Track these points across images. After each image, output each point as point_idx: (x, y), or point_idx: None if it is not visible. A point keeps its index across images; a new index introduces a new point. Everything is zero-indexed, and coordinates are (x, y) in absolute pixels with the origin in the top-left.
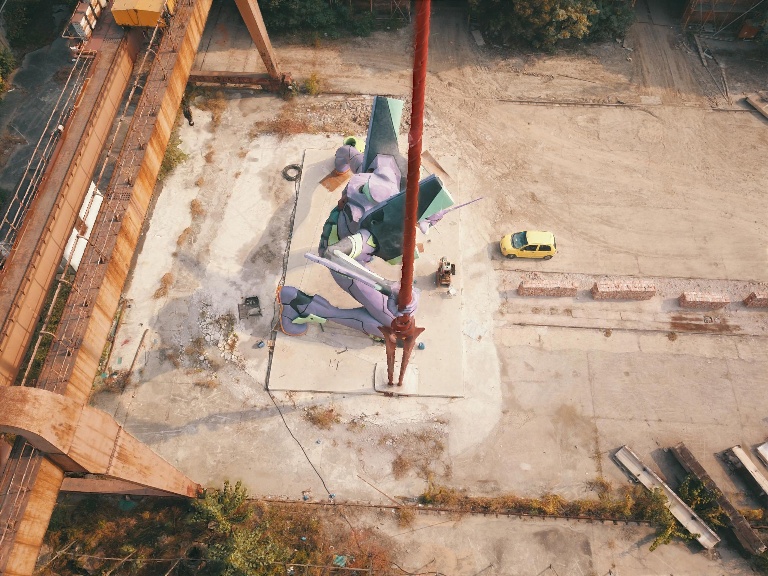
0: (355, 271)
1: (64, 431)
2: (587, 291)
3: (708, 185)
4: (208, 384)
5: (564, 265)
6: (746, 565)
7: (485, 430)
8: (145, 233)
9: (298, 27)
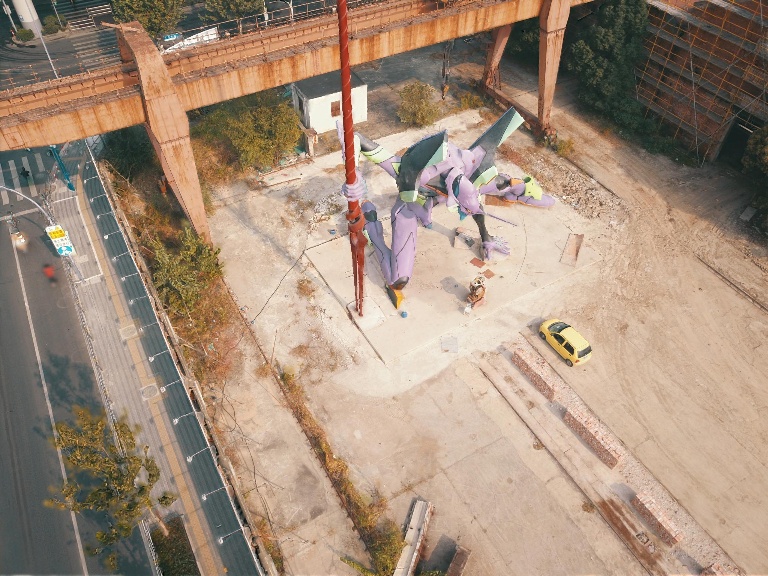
0: None
1: (154, 88)
2: None
3: None
4: (285, 222)
5: (576, 381)
6: None
7: (369, 392)
8: None
9: (607, 116)
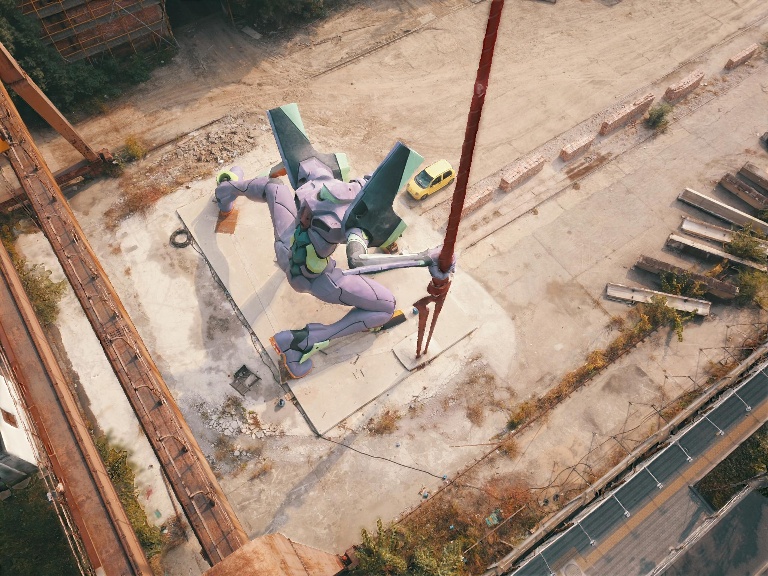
0: (390, 262)
1: (285, 567)
2: (497, 190)
3: (515, 62)
4: (264, 470)
5: None
6: (733, 309)
7: (511, 341)
8: (78, 383)
9: (72, 103)
